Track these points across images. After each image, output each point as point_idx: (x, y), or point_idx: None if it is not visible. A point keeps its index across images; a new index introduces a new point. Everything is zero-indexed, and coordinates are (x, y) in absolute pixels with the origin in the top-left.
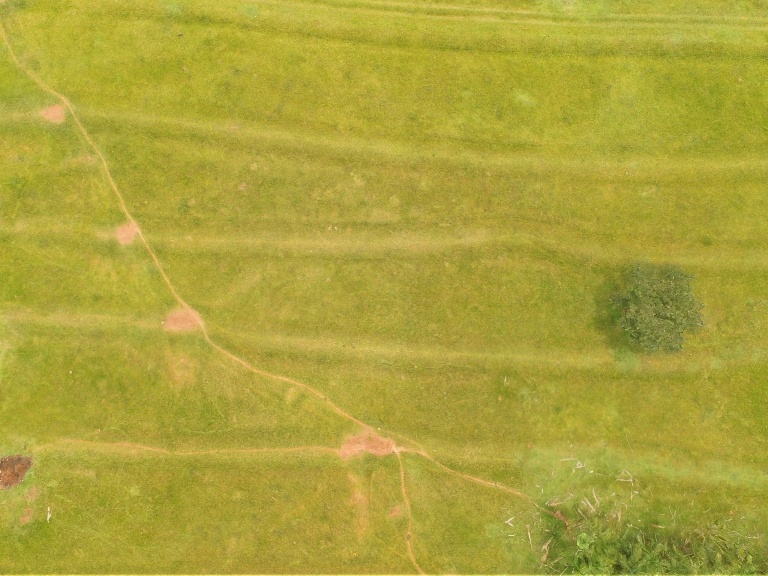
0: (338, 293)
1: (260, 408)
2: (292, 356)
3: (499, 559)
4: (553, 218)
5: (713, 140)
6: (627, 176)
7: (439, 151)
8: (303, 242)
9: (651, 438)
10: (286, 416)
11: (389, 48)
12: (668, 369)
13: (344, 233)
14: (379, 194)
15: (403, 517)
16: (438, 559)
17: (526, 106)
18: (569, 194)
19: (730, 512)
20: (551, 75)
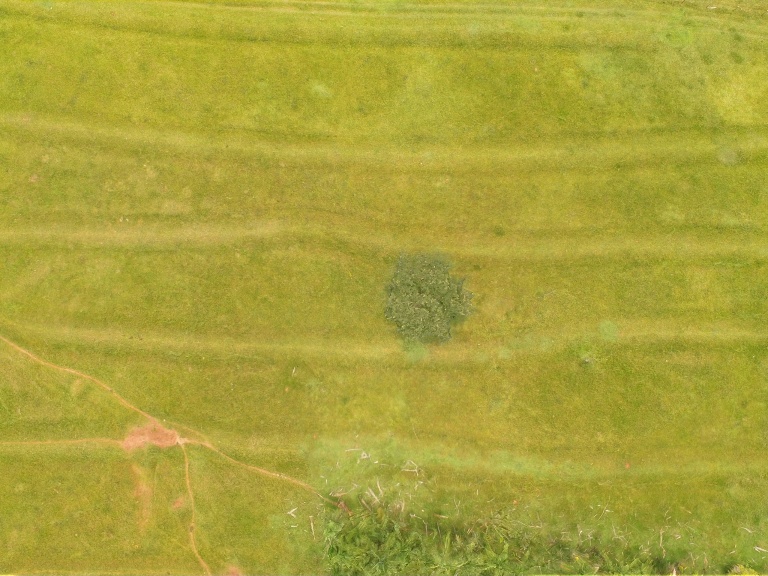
0: (128, 285)
1: (45, 400)
2: (80, 348)
3: (281, 550)
4: (346, 209)
5: (508, 130)
6: (422, 166)
7: (233, 142)
8: (93, 234)
9: (438, 428)
10: (71, 408)
11: (186, 39)
12: (456, 359)
13: (135, 225)
14: (171, 185)
15: (186, 508)
16: (220, 550)
17: (322, 97)
18: (363, 185)
19: (513, 501)
20: (348, 66)
